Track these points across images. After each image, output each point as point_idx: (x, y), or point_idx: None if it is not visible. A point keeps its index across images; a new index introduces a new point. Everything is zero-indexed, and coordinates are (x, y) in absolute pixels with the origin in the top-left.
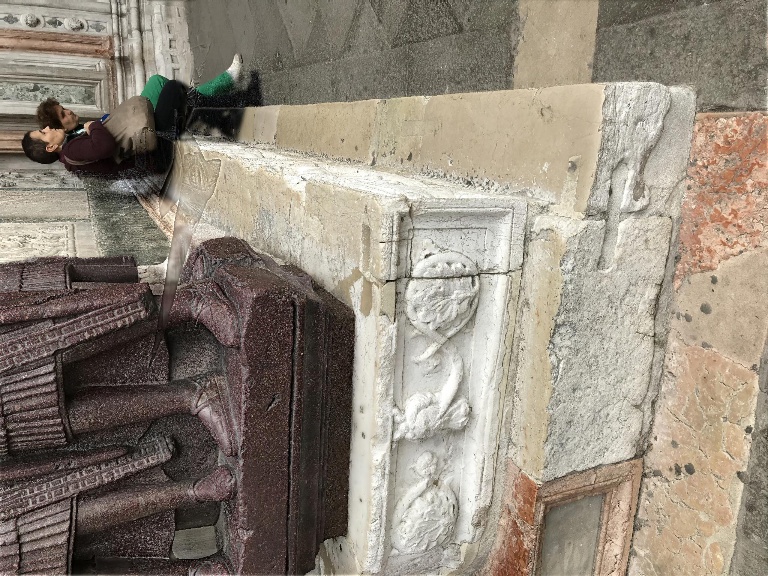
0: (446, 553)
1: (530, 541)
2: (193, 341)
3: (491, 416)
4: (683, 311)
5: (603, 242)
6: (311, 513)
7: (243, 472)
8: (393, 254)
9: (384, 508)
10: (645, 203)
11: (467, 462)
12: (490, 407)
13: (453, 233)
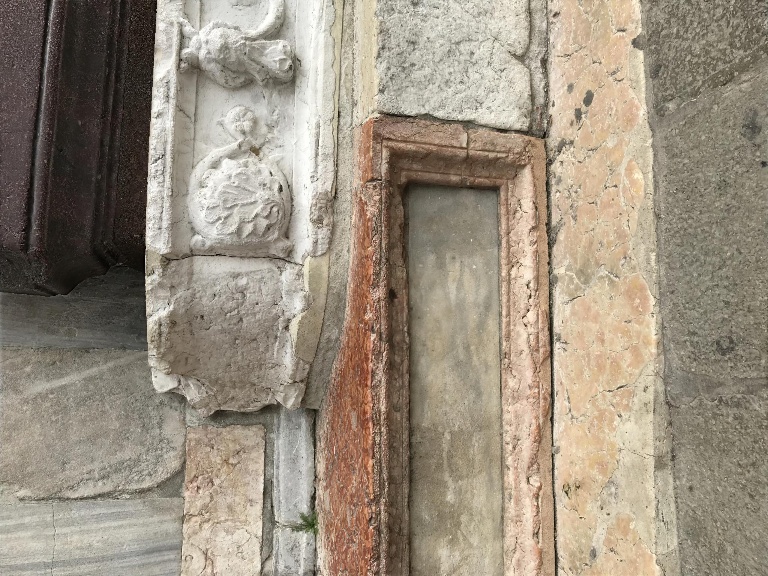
0: (284, 278)
1: (373, 205)
2: None
3: (323, 66)
4: None
5: None
6: (86, 171)
7: None
8: None
9: (169, 145)
10: None
11: (300, 134)
12: (321, 55)
13: None
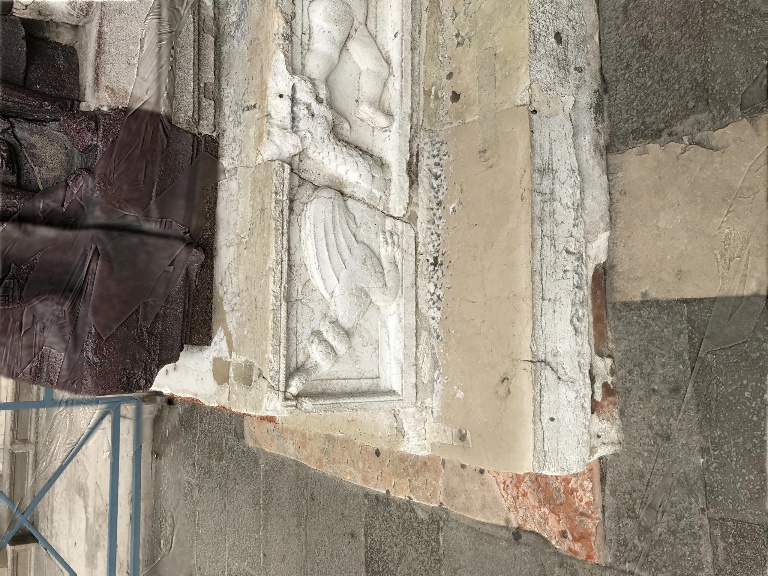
0: None
1: None
2: None
3: None
4: None
5: None
6: None
7: None
8: None
9: None
10: None
11: None
12: None
13: None
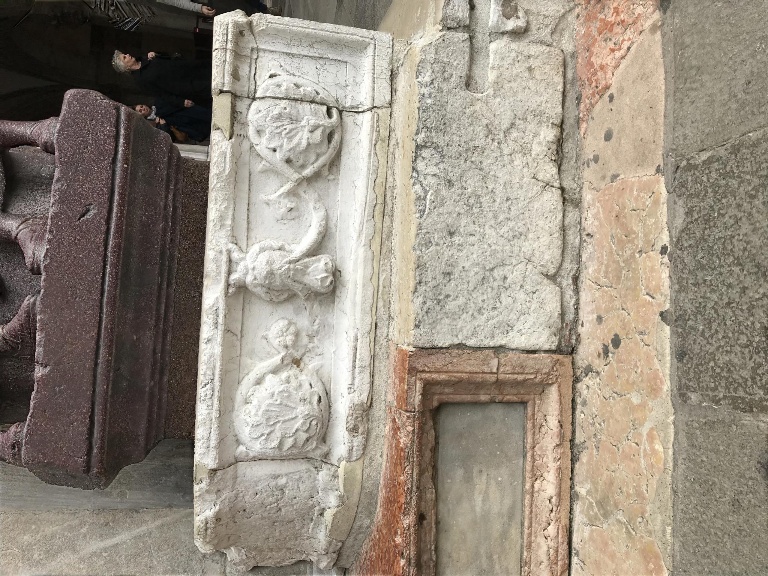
0: (321, 477)
1: (406, 435)
2: (41, 184)
3: (362, 280)
4: (591, 154)
5: (471, 61)
6: (140, 382)
7: (43, 289)
8: (227, 62)
9: (217, 370)
10: (520, 24)
11: (338, 343)
12: (360, 268)
13: (306, 61)
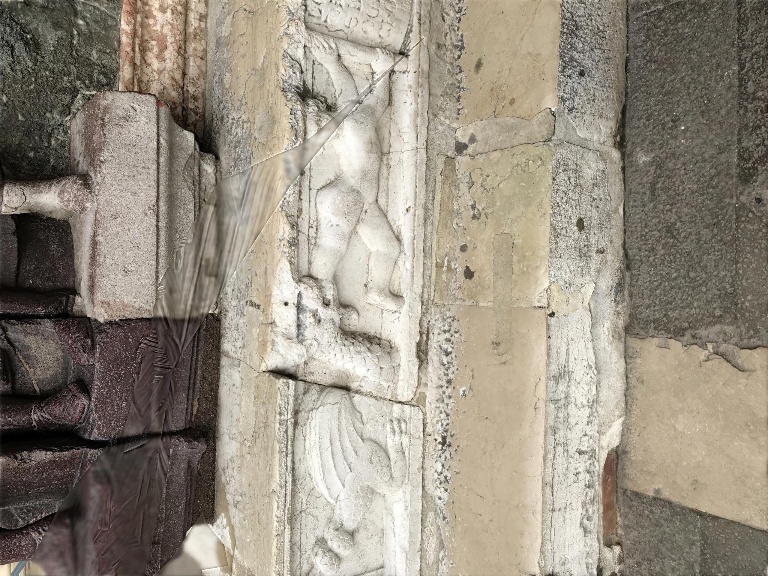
0: None
1: None
2: (30, 499)
3: None
4: None
5: None
6: None
7: None
8: None
9: None
10: None
11: None
12: None
13: None
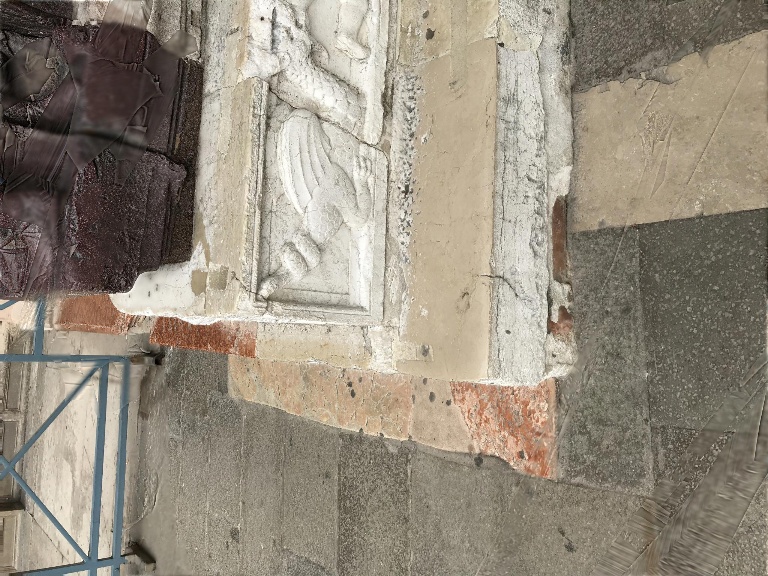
0: None
1: (234, 352)
2: None
3: None
4: None
5: None
6: None
7: None
8: None
9: None
10: None
11: None
12: None
13: None
